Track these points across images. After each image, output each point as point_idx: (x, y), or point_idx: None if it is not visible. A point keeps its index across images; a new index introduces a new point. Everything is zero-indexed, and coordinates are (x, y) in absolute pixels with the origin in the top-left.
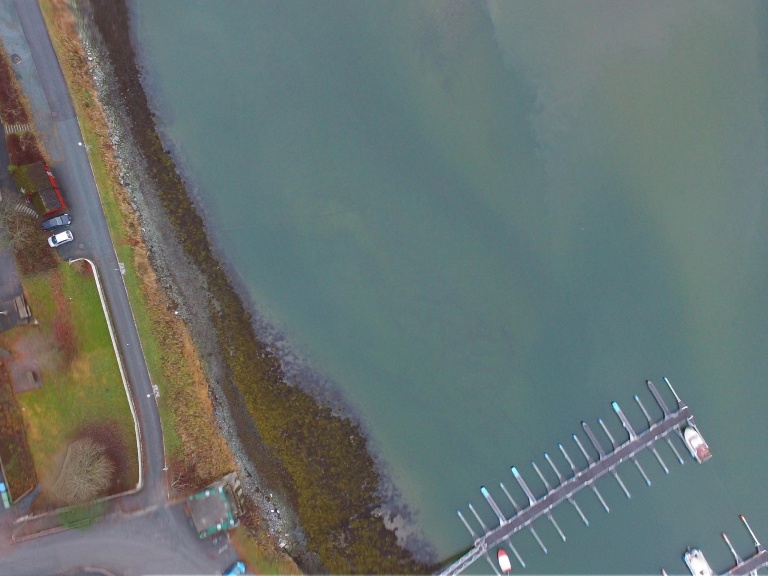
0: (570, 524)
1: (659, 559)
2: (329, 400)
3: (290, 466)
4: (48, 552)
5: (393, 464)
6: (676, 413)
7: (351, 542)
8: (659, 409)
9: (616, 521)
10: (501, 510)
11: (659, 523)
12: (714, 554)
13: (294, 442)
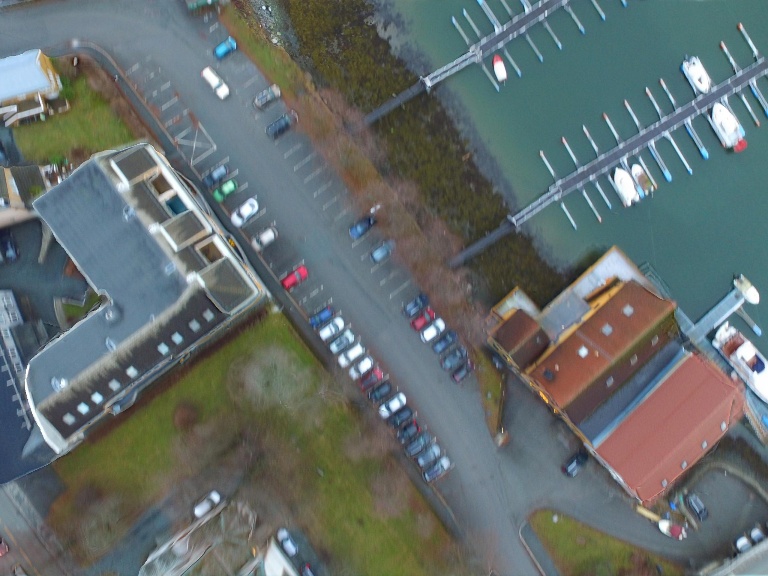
0: (566, 31)
1: (657, 68)
2: None
3: None
4: (36, 24)
5: None
6: None
7: (344, 48)
8: None
9: (612, 29)
10: (496, 15)
11: (656, 31)
12: (712, 63)
13: None
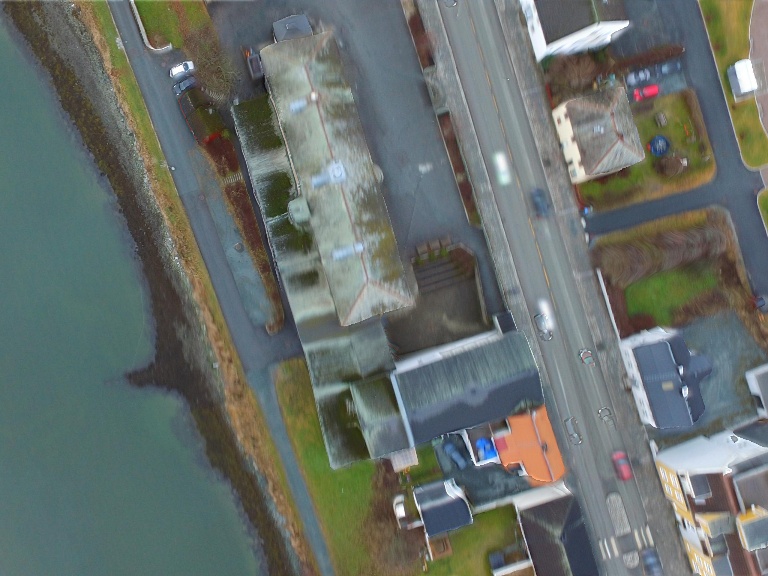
0: None
1: None
2: None
3: None
4: None
5: None
6: None
7: None
8: None
9: None
10: None
11: None
12: None
13: None
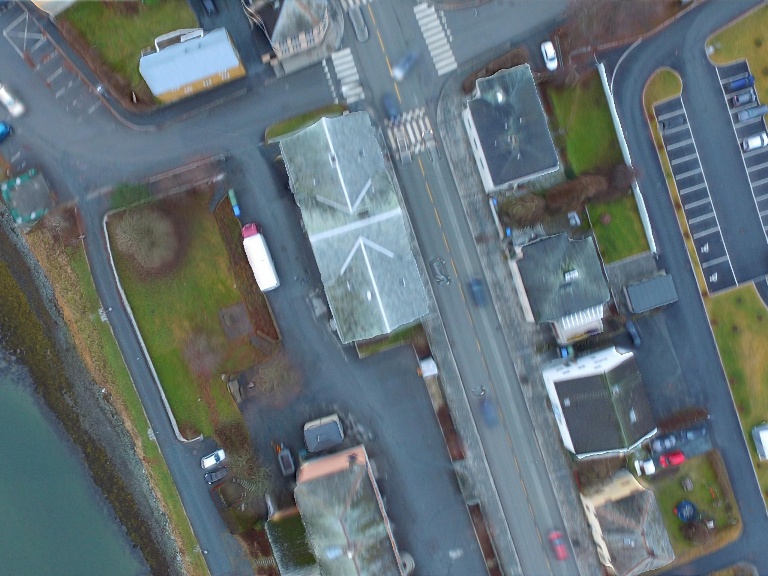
0: None
1: None
2: None
3: None
4: (193, 144)
5: None
6: None
7: None
8: None
9: None
10: None
11: None
12: None
13: None
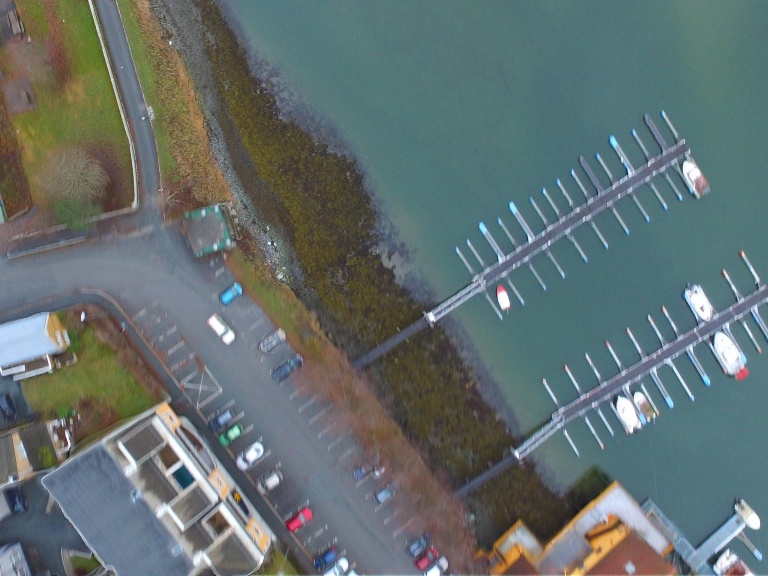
0: (569, 260)
1: (659, 296)
2: (325, 136)
3: (286, 201)
4: (44, 272)
5: (390, 202)
6: (674, 147)
7: (349, 279)
8: (657, 145)
9: (615, 258)
10: (499, 246)
11: (658, 259)
12: (714, 291)
13: (290, 177)
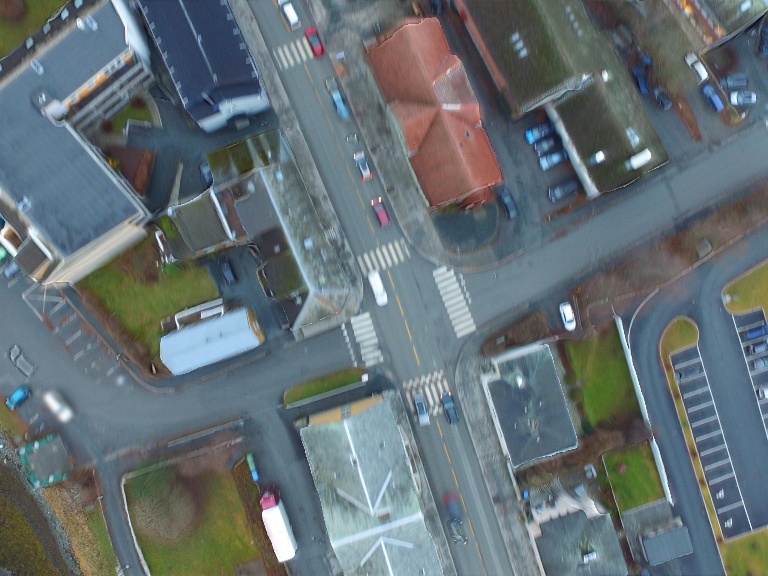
0: None
1: None
2: None
3: None
4: (212, 406)
5: None
6: None
7: None
8: None
9: None
10: None
11: None
12: None
13: None
